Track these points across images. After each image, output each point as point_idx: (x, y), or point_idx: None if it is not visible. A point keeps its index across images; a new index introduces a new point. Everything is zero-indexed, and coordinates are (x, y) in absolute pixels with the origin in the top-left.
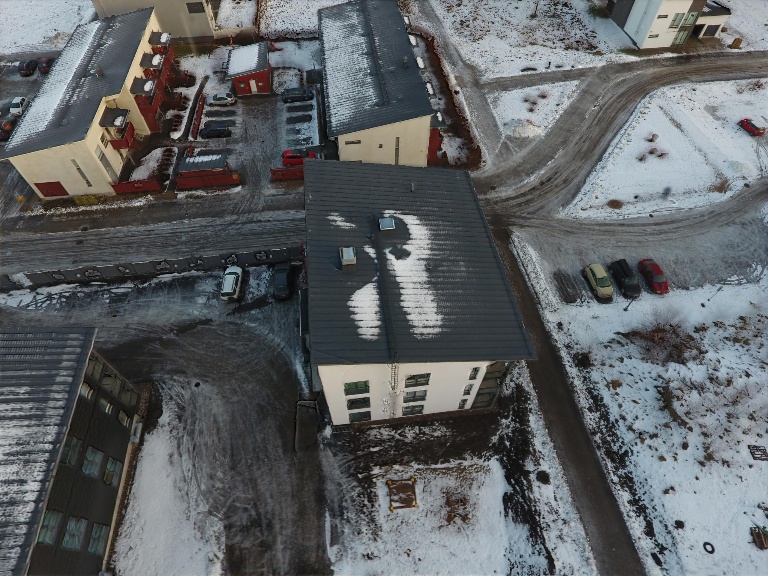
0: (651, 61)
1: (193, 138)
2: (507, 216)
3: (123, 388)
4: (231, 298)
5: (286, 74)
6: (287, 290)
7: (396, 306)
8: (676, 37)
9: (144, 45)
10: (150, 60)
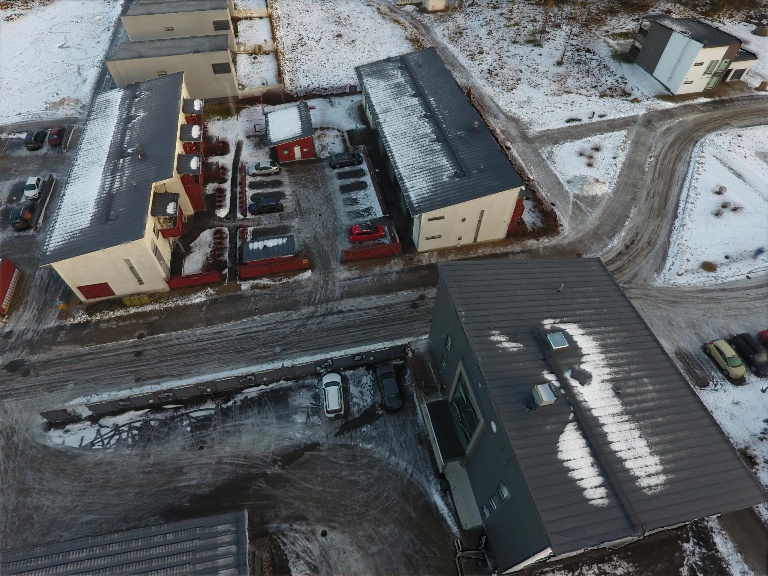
0: (688, 107)
1: (243, 215)
2: None
3: (254, 562)
4: (339, 415)
5: (327, 136)
6: (400, 399)
7: (608, 451)
8: (708, 82)
9: (180, 115)
10: (189, 132)
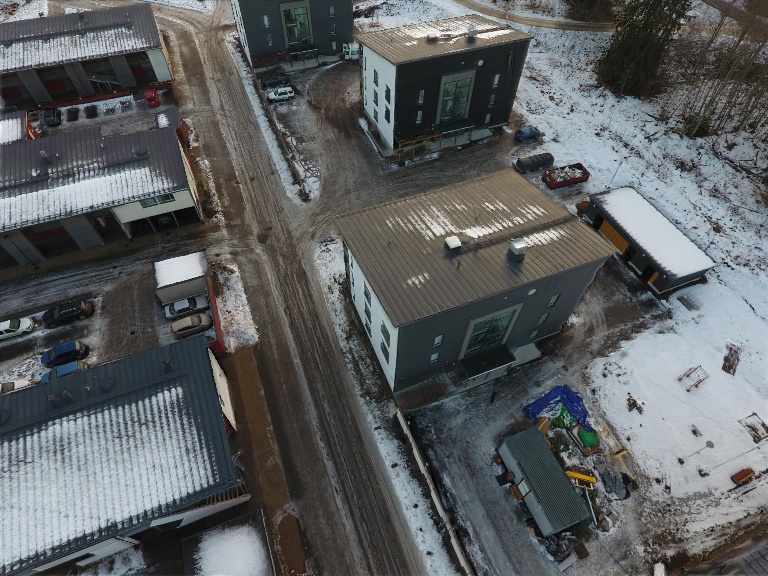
0: None
1: None
2: (211, 27)
3: None
4: None
5: None
6: None
7: None
8: None
9: None
10: None
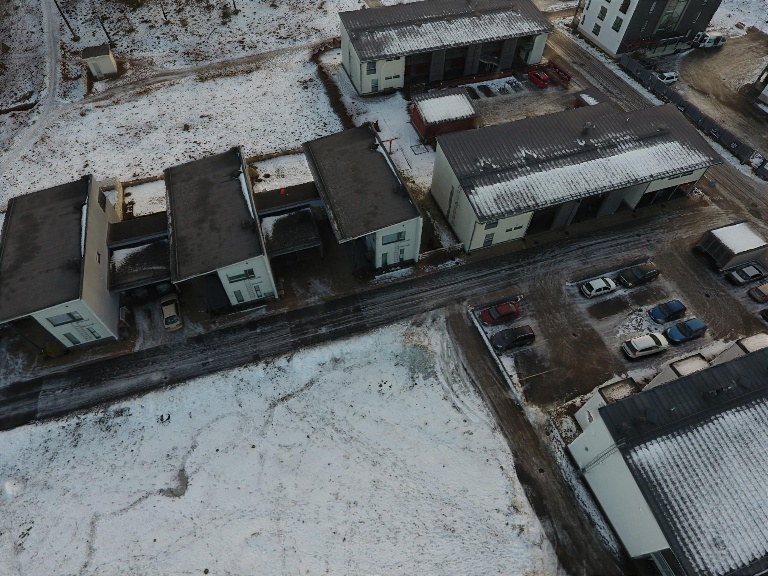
0: None
1: None
2: None
3: None
4: None
5: None
6: None
7: None
8: None
9: None
10: None
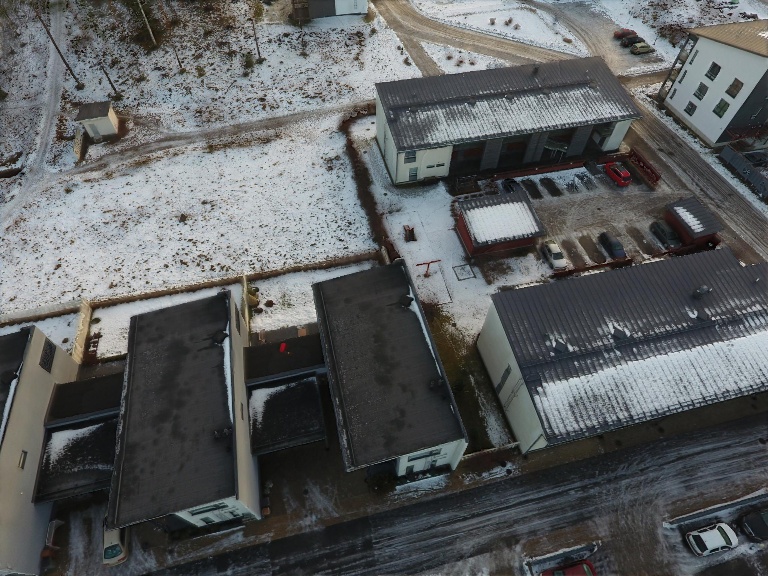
0: (382, 13)
1: None
2: None
3: None
4: None
5: None
6: None
7: None
8: None
9: None
10: None
